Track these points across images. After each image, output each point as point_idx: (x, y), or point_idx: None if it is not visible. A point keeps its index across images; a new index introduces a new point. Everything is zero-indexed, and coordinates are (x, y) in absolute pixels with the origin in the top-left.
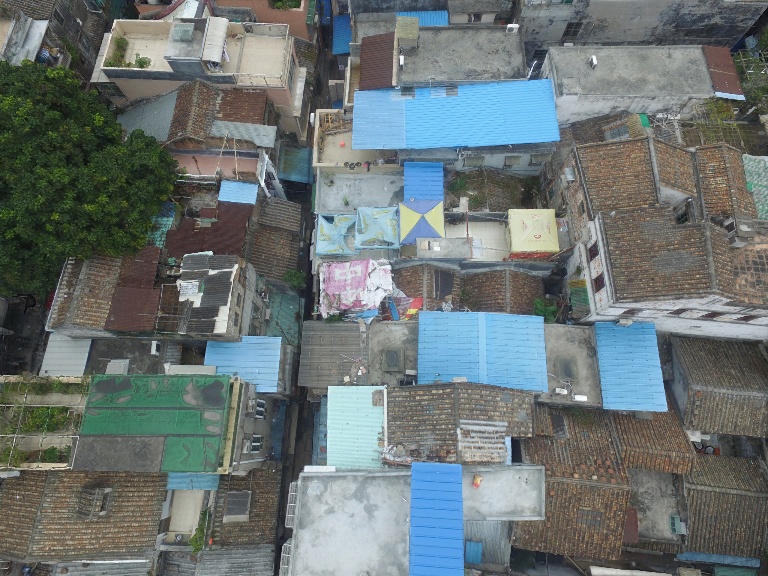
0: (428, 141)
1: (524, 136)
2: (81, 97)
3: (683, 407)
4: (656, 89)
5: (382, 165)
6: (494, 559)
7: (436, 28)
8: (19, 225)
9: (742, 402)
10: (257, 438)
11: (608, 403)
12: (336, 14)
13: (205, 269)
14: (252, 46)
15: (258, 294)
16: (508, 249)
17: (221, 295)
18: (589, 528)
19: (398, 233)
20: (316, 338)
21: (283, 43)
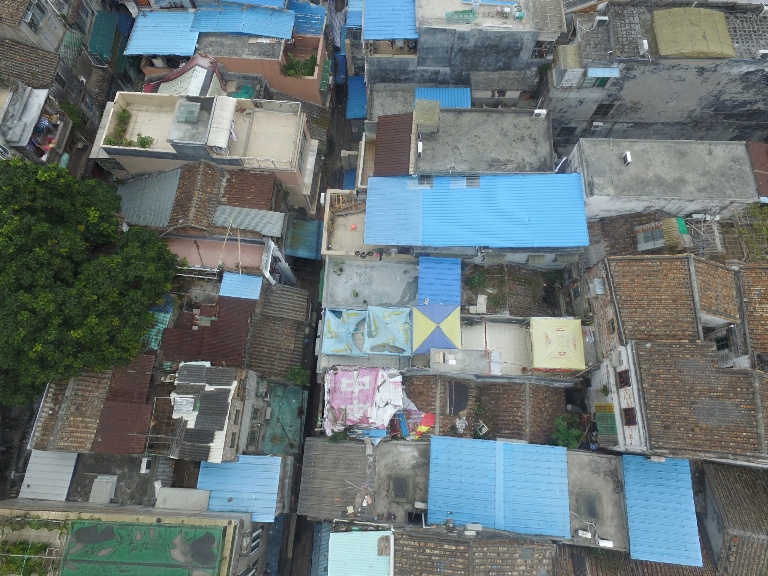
0: (446, 238)
1: (550, 238)
2: (76, 192)
3: (717, 550)
4: (695, 191)
5: (395, 255)
6: None
7: (458, 110)
8: None
9: None
10: (251, 575)
11: (636, 552)
12: (351, 75)
13: (201, 383)
14: (261, 122)
15: (258, 397)
16: (528, 356)
17: (217, 417)
18: None
19: (410, 339)
20: (319, 459)
21: (294, 120)
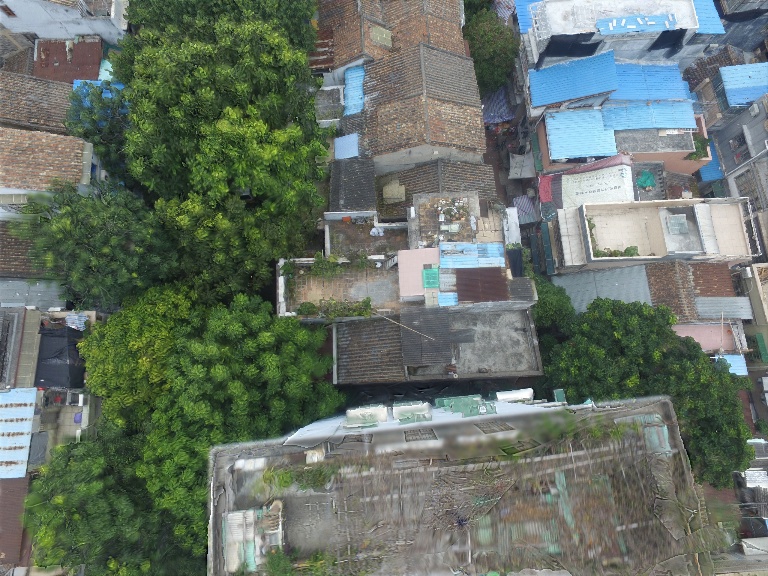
0: None
1: None
2: None
3: None
4: None
5: None
6: None
7: None
8: (707, 473)
9: None
10: None
11: None
12: None
13: (766, 457)
14: None
15: None
16: None
17: None
18: None
19: None
20: None
21: (732, 210)
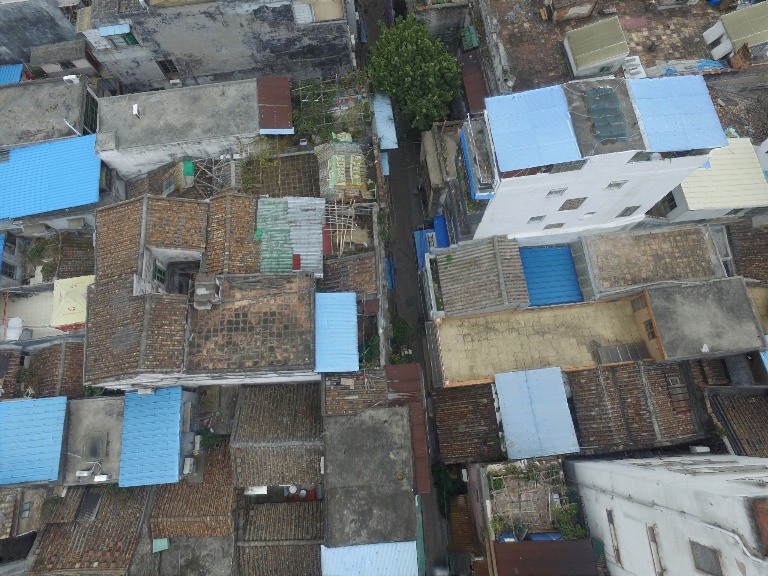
0: None
1: (64, 200)
2: None
3: None
4: (201, 133)
5: None
6: None
7: None
8: None
9: (284, 453)
10: None
11: (122, 481)
12: None
13: None
14: None
15: None
16: None
17: None
18: None
19: None
20: None
21: None
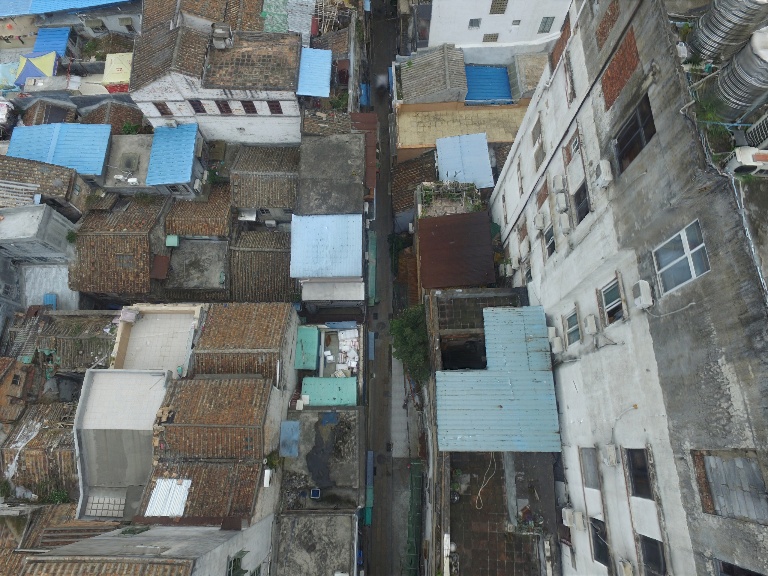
0: (47, 7)
1: None
2: None
3: None
4: None
5: (30, 36)
6: (69, 308)
7: None
8: None
9: (271, 181)
10: None
11: (149, 180)
12: None
13: None
14: None
15: None
16: None
17: None
18: (125, 270)
19: None
20: None
21: None
